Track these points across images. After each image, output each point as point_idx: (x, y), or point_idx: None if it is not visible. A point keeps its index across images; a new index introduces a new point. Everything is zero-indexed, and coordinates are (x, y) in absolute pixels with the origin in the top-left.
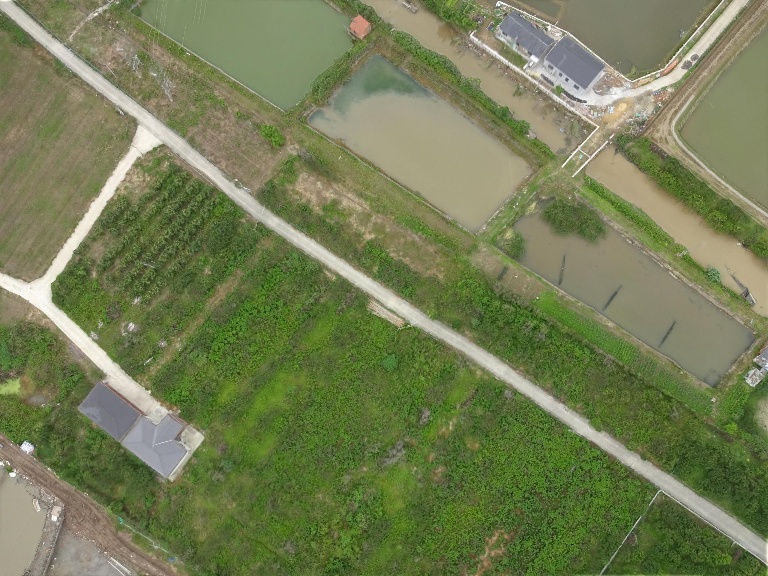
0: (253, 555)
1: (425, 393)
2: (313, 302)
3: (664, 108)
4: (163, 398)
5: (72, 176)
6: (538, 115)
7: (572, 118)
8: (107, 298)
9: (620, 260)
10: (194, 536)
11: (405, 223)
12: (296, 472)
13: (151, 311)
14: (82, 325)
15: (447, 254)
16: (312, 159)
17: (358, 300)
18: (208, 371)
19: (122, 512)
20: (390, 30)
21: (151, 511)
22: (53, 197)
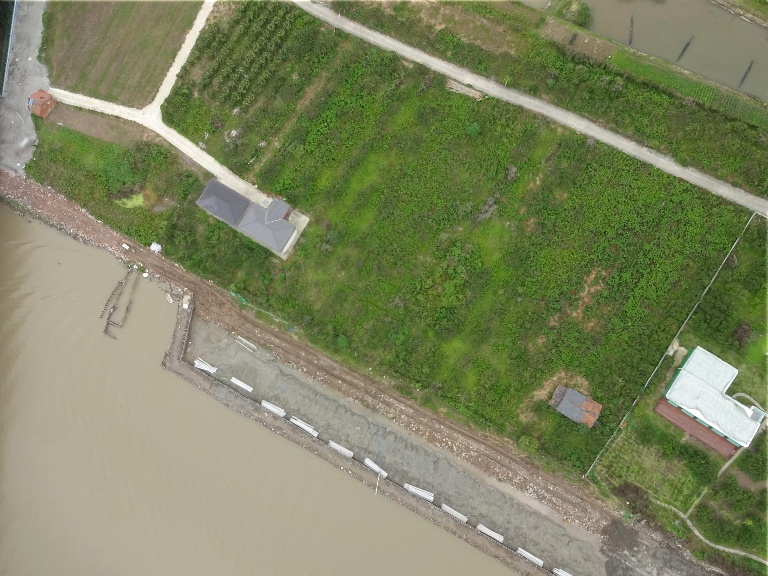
0: (365, 315)
1: (510, 153)
2: (394, 88)
3: None
4: (269, 190)
5: (167, 15)
6: None
7: None
8: (209, 112)
9: (689, 13)
10: (310, 306)
11: (472, 9)
12: (396, 237)
13: (249, 116)
14: (191, 138)
15: (516, 29)
16: None
17: (436, 79)
18: (306, 162)
19: (244, 290)
20: None
21: (269, 289)
22: (153, 35)
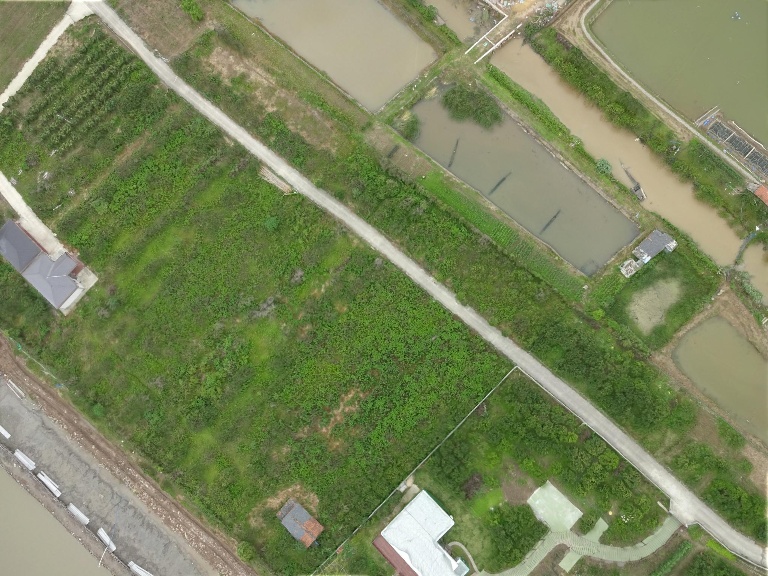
0: (128, 387)
1: (302, 255)
2: (209, 164)
3: (576, 0)
4: (66, 241)
5: (11, 38)
6: (451, 4)
7: (484, 8)
8: (28, 148)
9: (513, 147)
10: (79, 366)
11: (306, 98)
12: (174, 316)
13: (64, 162)
14: (4, 171)
15: (341, 129)
16: (225, 32)
17: (249, 164)
18: (108, 220)
19: (19, 338)
20: None
21: (45, 340)
22: None
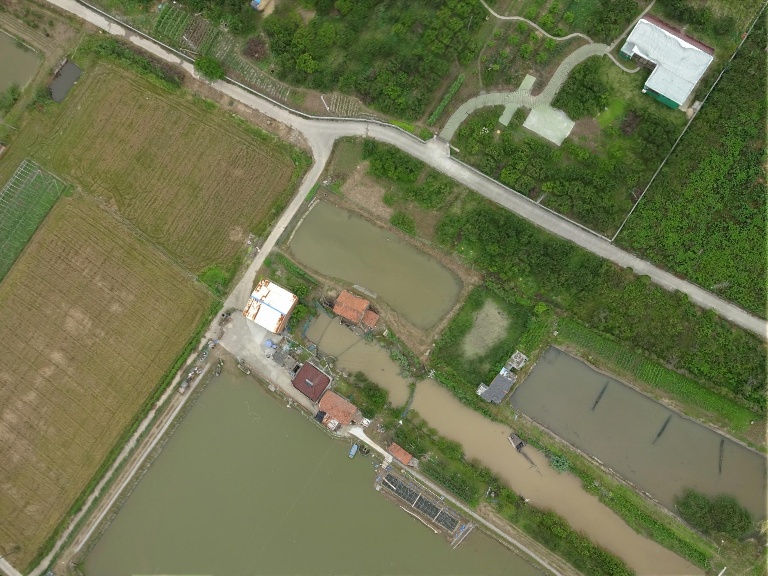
0: None
1: None
2: None
3: None
4: None
5: None
6: None
7: None
8: None
9: (658, 473)
10: None
11: None
12: None
13: None
14: None
15: None
16: None
17: None
18: None
19: None
20: None
21: None
22: None
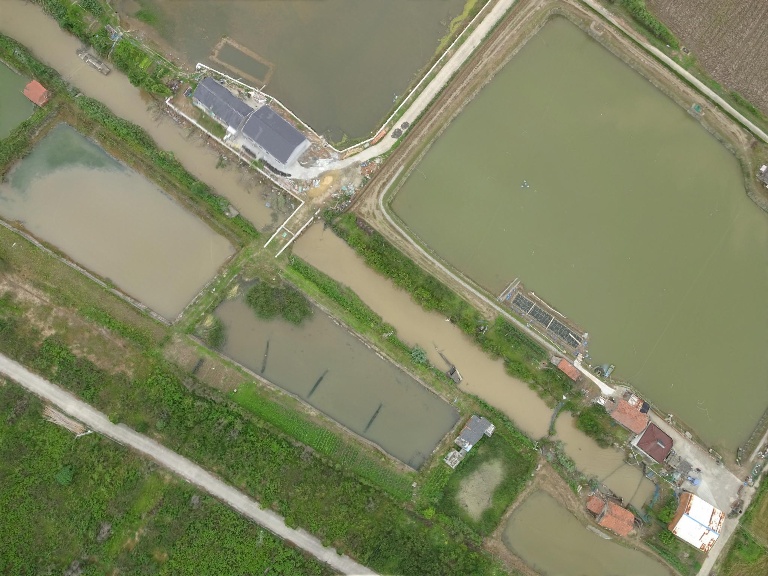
0: None
1: (106, 504)
2: None
3: (372, 180)
4: None
5: None
6: (243, 189)
7: (279, 192)
8: None
9: (326, 343)
10: None
11: (89, 316)
12: None
13: None
14: None
15: (135, 349)
16: None
17: (28, 408)
18: None
19: None
20: (75, 96)
21: None
22: None
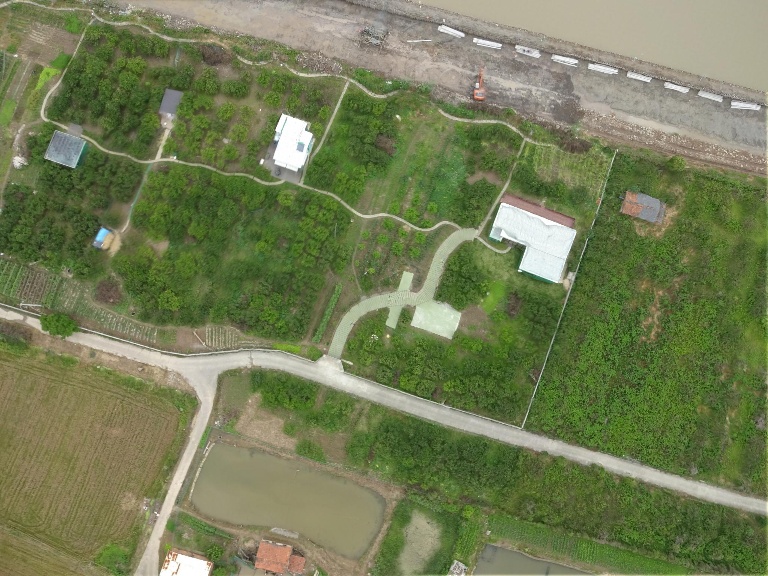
0: None
1: (766, 444)
2: None
3: None
4: None
5: None
6: None
7: None
8: None
9: None
10: None
11: None
12: None
13: None
14: None
15: None
16: None
17: None
18: None
19: None
20: None
21: None
22: None
